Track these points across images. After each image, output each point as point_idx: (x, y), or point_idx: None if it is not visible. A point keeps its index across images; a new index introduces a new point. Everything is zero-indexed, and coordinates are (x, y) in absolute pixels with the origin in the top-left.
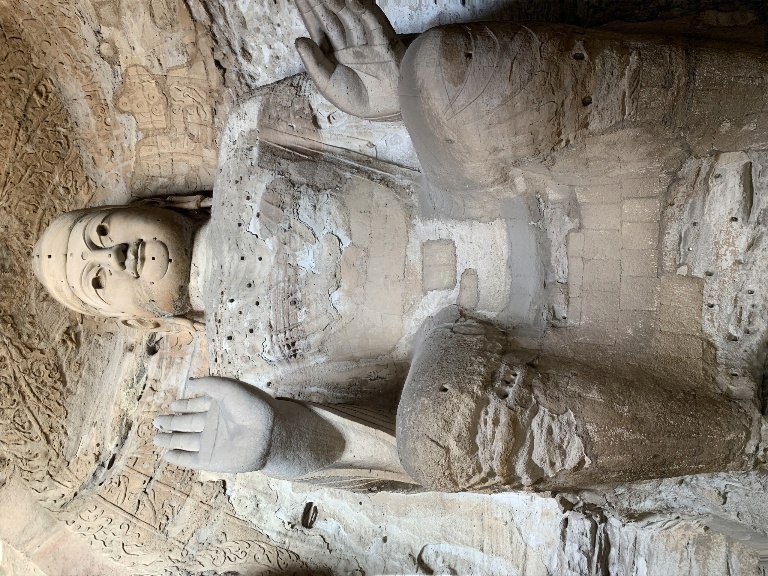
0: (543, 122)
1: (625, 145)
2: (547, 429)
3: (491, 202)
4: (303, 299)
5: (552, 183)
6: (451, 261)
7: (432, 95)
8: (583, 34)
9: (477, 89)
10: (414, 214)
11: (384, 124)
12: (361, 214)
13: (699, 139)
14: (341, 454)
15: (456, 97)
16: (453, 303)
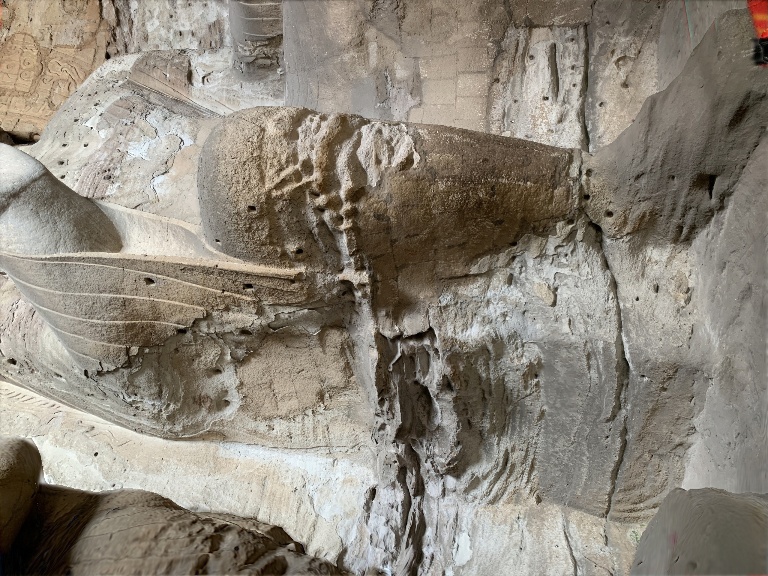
0: None
1: None
2: (377, 130)
3: (344, 89)
4: (121, 176)
5: (400, 56)
6: None
7: None
8: None
9: None
10: None
11: (254, 91)
12: None
13: None
14: None
15: None
16: None
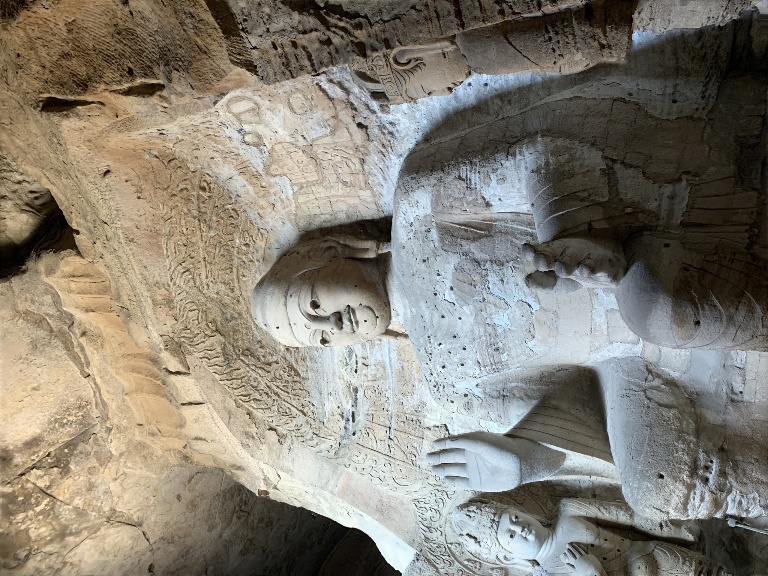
0: None
1: None
2: (738, 502)
3: None
4: (504, 347)
5: None
6: None
7: (662, 343)
8: None
9: (703, 343)
10: None
11: None
12: None
13: None
14: (564, 462)
15: (683, 344)
16: (638, 356)
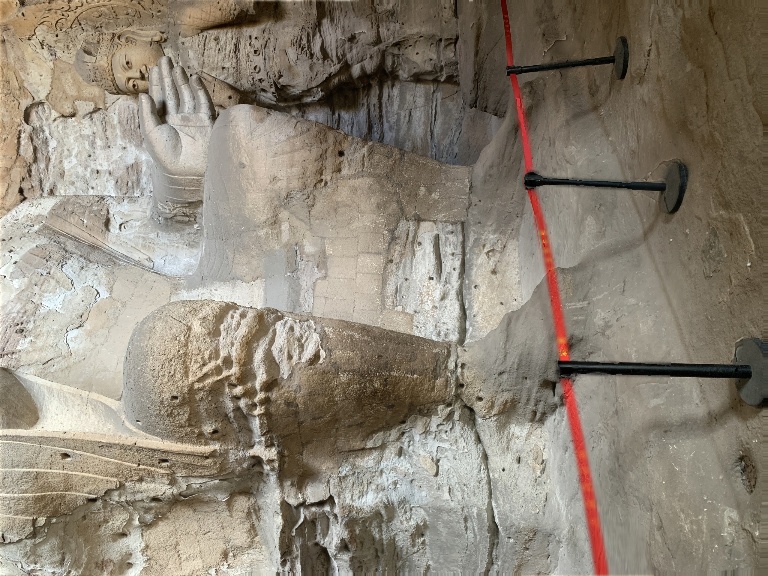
0: (312, 161)
1: (363, 192)
2: (289, 327)
3: (257, 257)
4: (34, 330)
5: (309, 235)
6: None
7: (239, 124)
8: None
9: (272, 128)
10: (180, 289)
11: (170, 240)
12: (128, 282)
13: (407, 199)
14: (27, 429)
15: (256, 129)
16: None
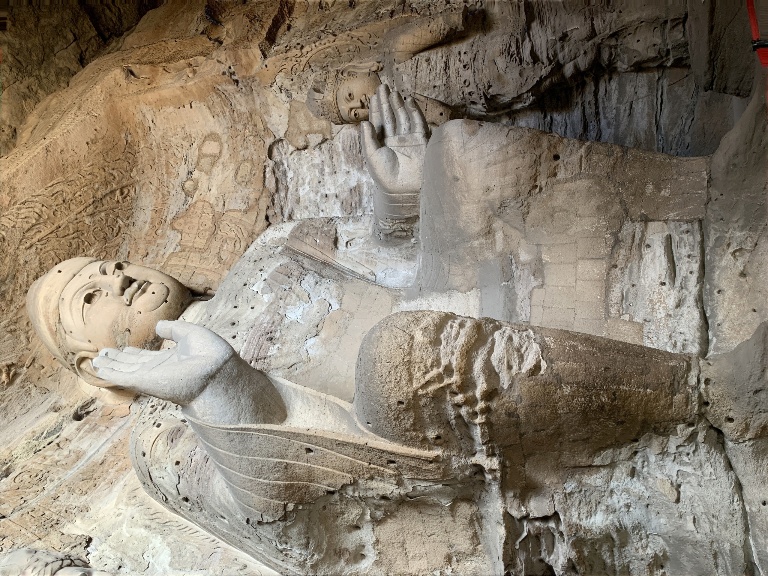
0: (525, 168)
1: (581, 196)
2: (508, 337)
3: (472, 267)
4: (280, 338)
5: (524, 243)
6: None
7: (452, 139)
8: None
9: (484, 139)
10: (400, 300)
11: (390, 254)
12: (354, 294)
13: (632, 198)
14: (279, 424)
15: (468, 142)
16: None
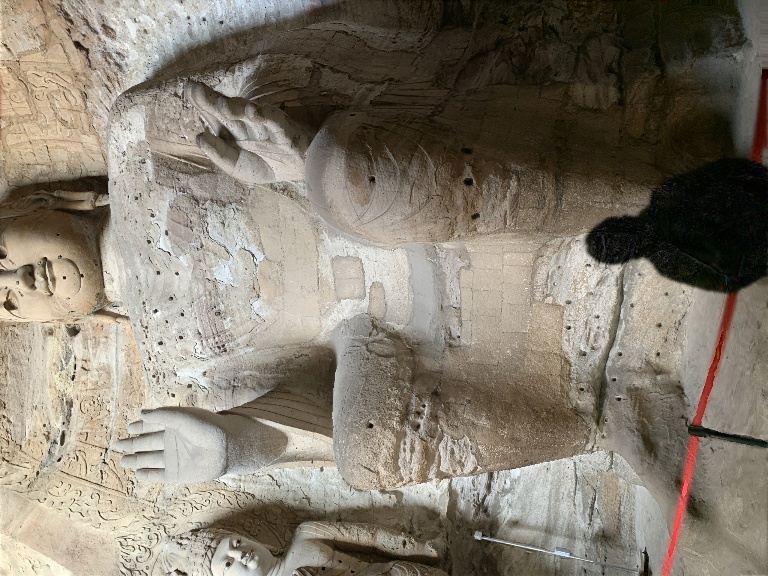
0: (439, 228)
1: (506, 238)
2: (450, 451)
3: None
4: (227, 310)
5: None
6: (360, 276)
7: (341, 211)
8: (471, 153)
9: (382, 209)
10: (321, 229)
11: None
12: (270, 229)
13: (564, 234)
14: (285, 447)
15: (363, 213)
16: (365, 312)
